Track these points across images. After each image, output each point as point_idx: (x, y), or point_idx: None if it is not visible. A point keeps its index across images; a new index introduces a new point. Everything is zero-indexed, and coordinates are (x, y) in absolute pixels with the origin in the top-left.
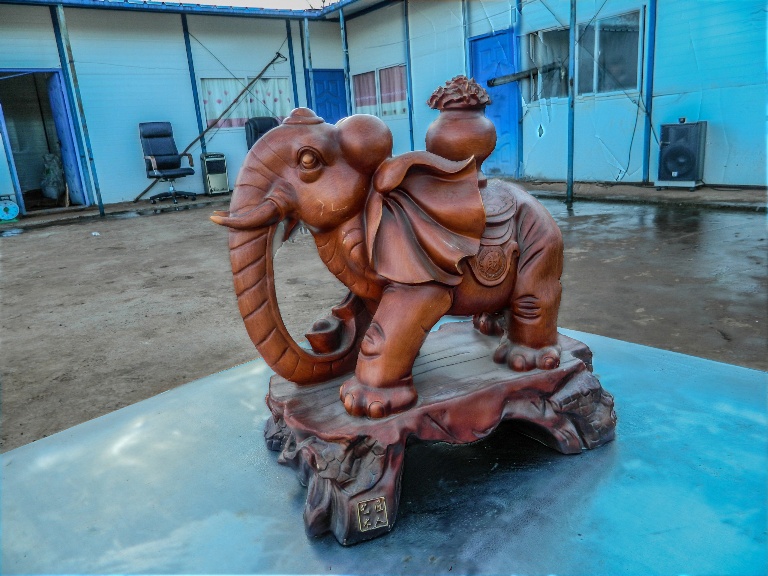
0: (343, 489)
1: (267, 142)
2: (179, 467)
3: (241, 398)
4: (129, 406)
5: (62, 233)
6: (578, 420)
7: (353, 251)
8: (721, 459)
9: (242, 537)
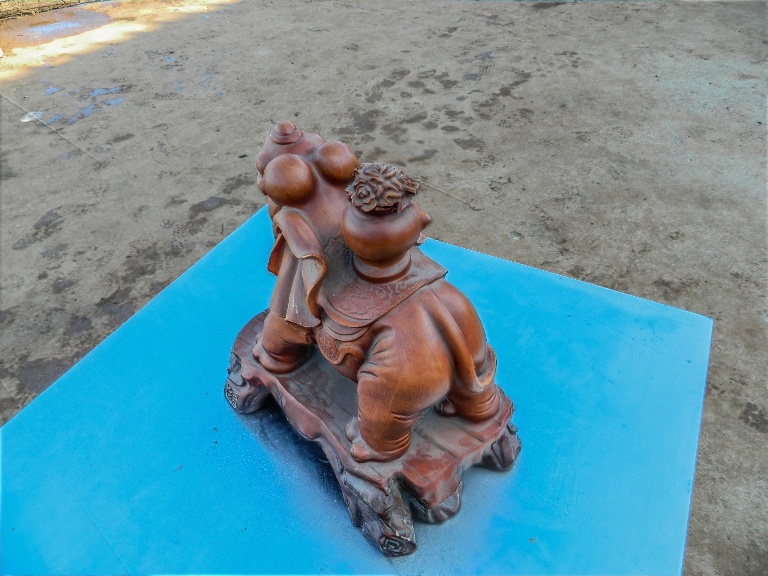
0: None
1: None
2: None
3: None
4: None
5: None
6: None
7: None
8: None
9: (232, 343)
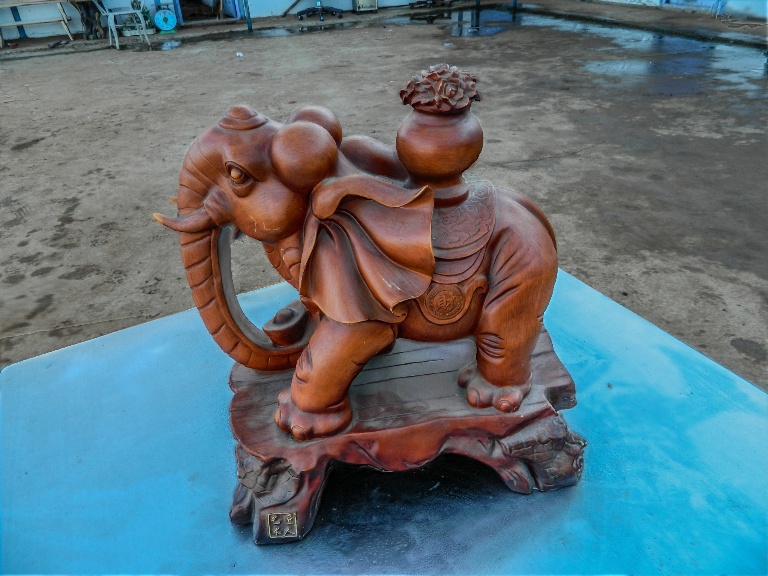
0: (259, 498)
1: (200, 145)
2: (167, 407)
3: None
4: (158, 320)
5: (211, 50)
6: (532, 463)
7: (291, 270)
8: (679, 546)
9: (183, 505)
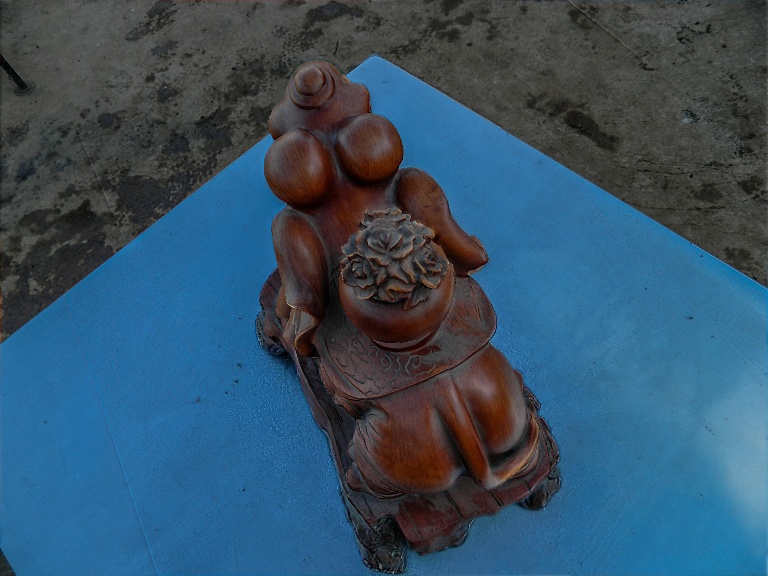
0: None
1: None
2: None
3: (480, 198)
4: (474, 114)
5: None
6: None
7: None
8: None
9: None
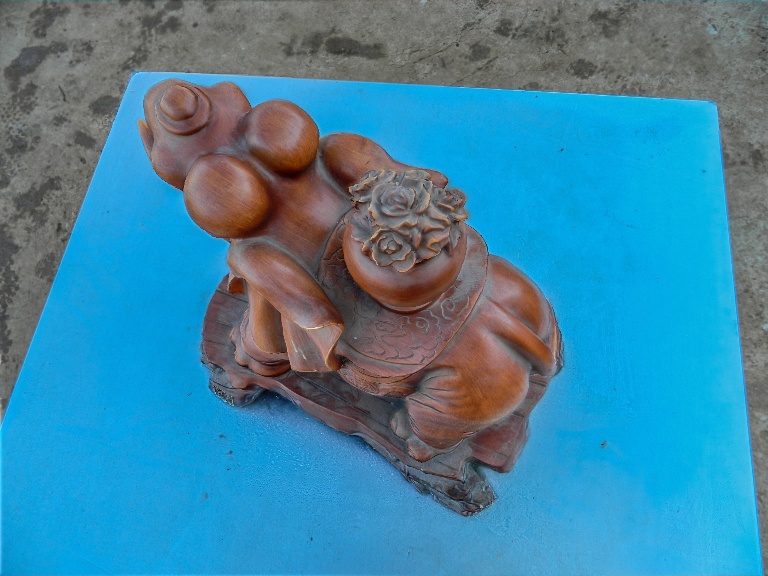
0: None
1: None
2: None
3: None
4: (272, 79)
5: None
6: None
7: None
8: None
9: (186, 317)
